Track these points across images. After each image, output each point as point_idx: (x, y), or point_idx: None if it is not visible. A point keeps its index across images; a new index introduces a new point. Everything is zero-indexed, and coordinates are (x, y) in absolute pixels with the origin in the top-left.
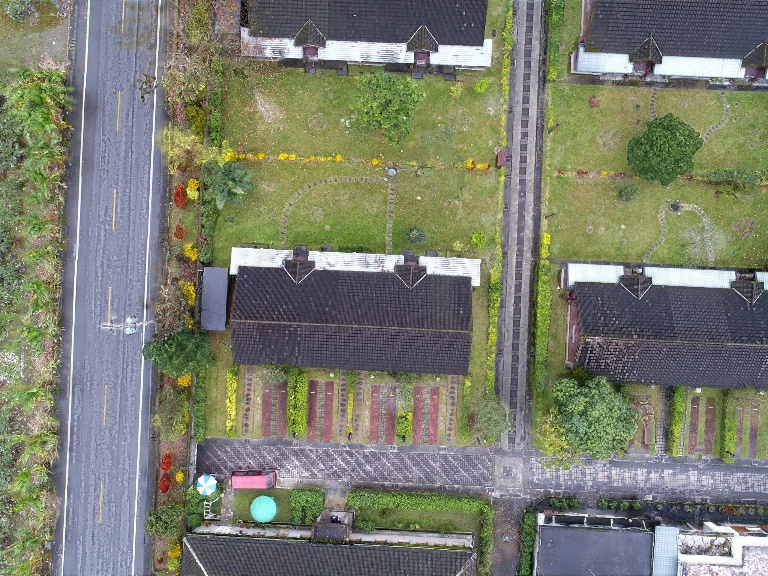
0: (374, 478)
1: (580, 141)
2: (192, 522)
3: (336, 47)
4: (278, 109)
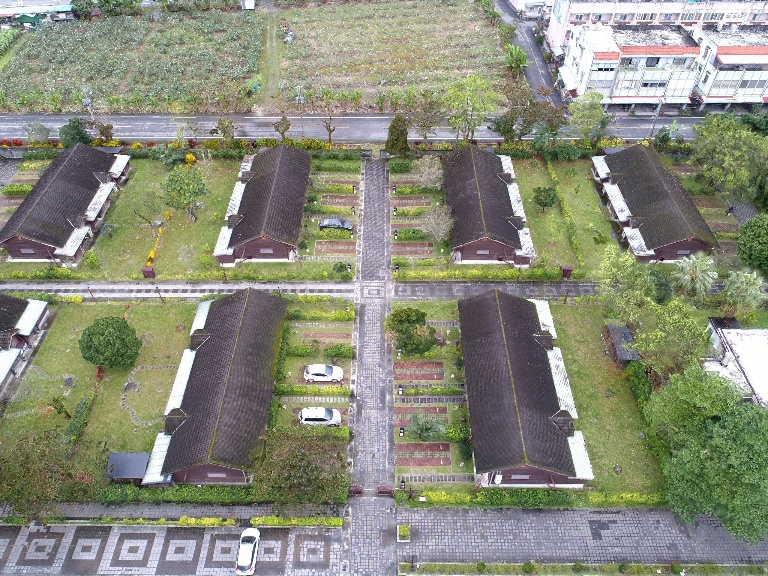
0: None
1: (151, 321)
2: None
3: (242, 188)
4: (216, 179)
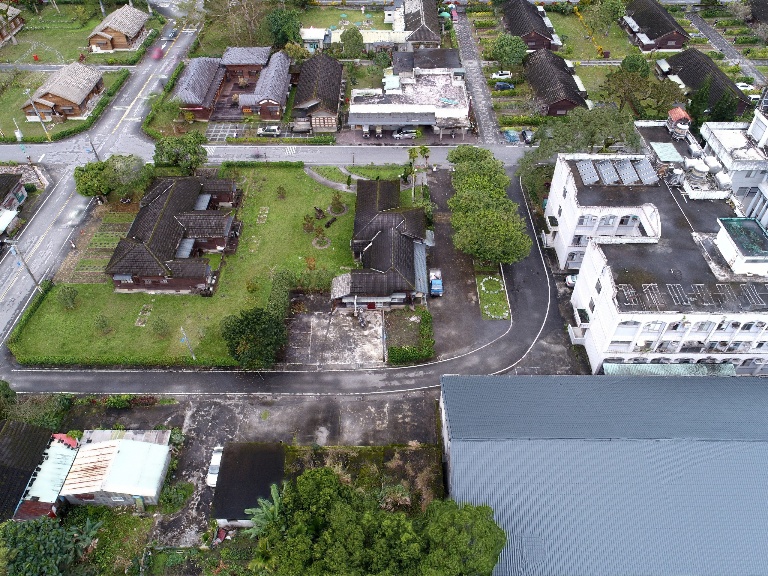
0: (460, 39)
1: None
2: (437, 6)
3: None
4: None
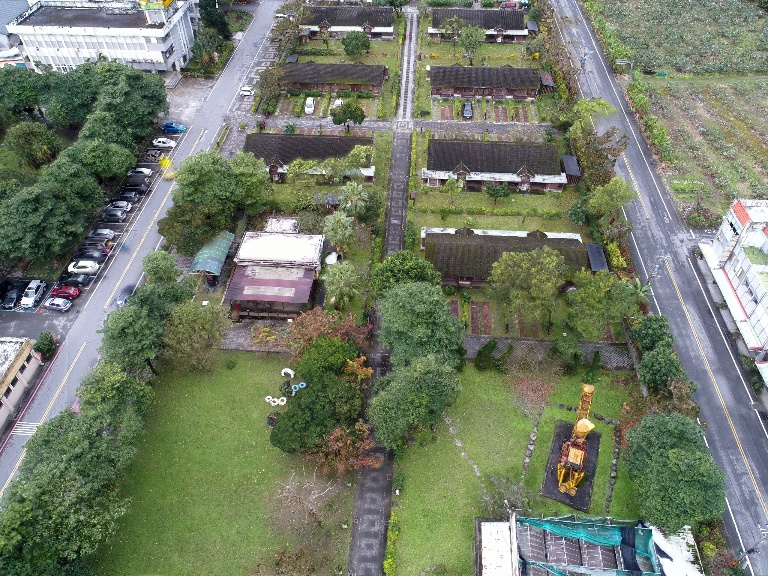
0: None
1: None
2: None
3: None
4: None
